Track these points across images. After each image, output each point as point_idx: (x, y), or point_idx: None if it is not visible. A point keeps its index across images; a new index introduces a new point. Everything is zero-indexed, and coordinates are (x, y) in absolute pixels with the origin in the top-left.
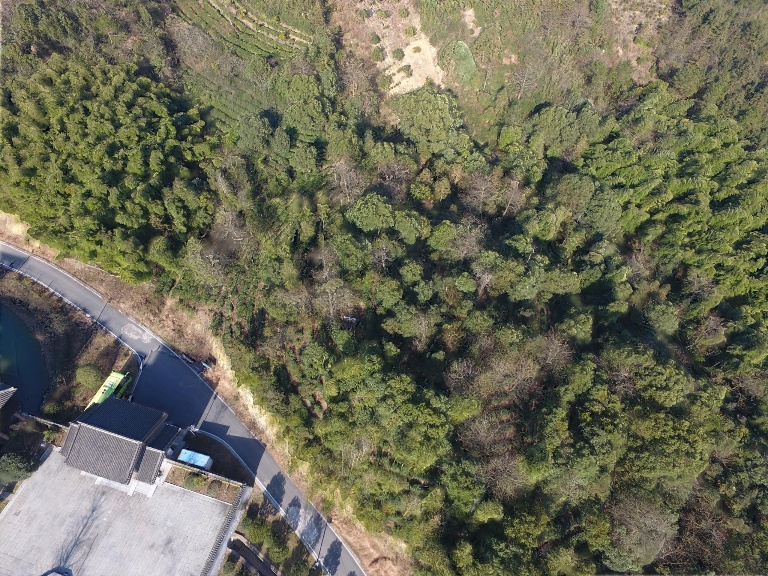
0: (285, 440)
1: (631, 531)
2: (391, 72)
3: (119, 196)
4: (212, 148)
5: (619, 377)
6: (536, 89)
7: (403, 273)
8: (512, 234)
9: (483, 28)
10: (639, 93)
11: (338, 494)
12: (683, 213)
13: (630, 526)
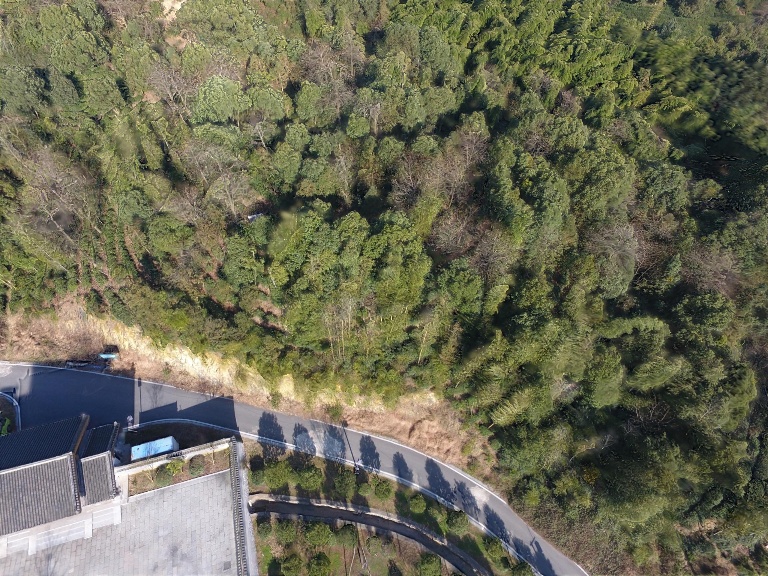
0: (252, 376)
1: (609, 257)
2: None
3: None
4: None
5: (533, 142)
6: None
7: (290, 138)
8: None
9: None
10: None
11: (340, 393)
12: (494, 38)
13: (607, 251)
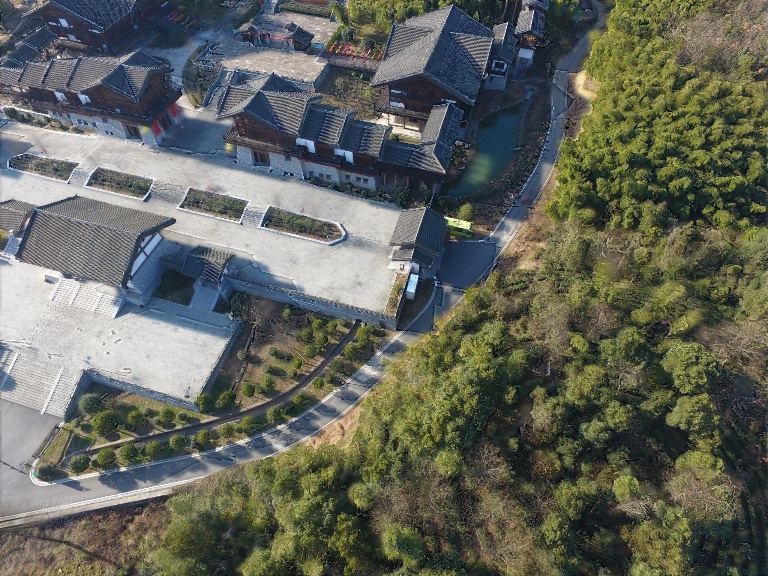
0: None
1: None
2: None
3: (626, 175)
4: (731, 226)
5: None
6: None
7: None
8: None
9: None
10: None
11: None
12: None
13: None
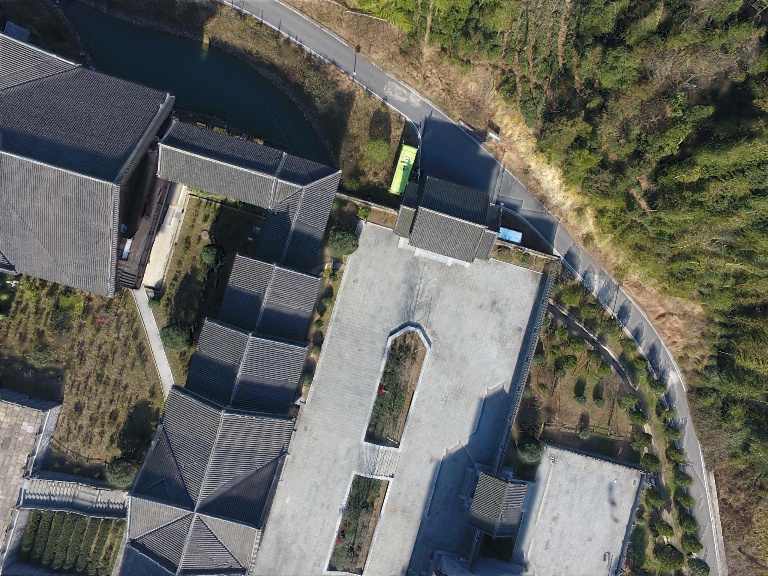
0: (587, 216)
1: None
2: None
3: None
4: None
5: None
6: None
7: None
8: None
9: None
10: None
11: (636, 264)
12: None
13: None
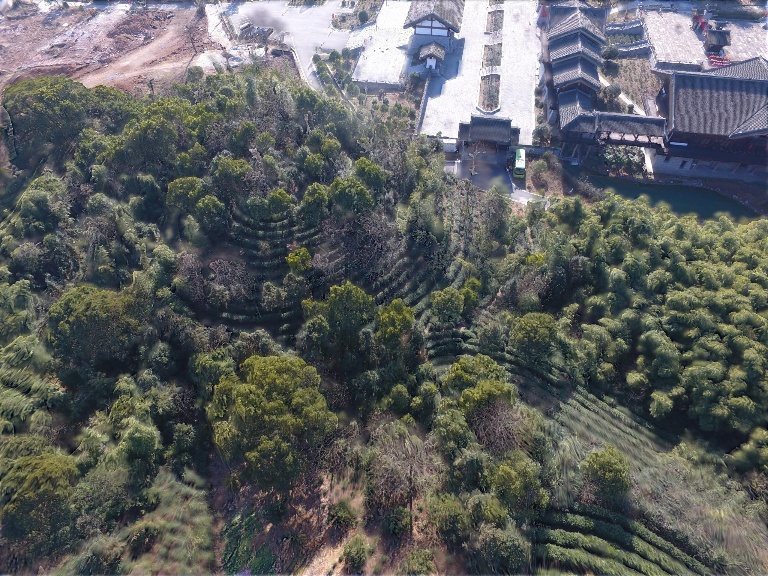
0: None
1: None
2: None
3: None
4: None
5: None
6: None
7: None
8: (206, 256)
9: None
10: None
11: None
12: None
13: None
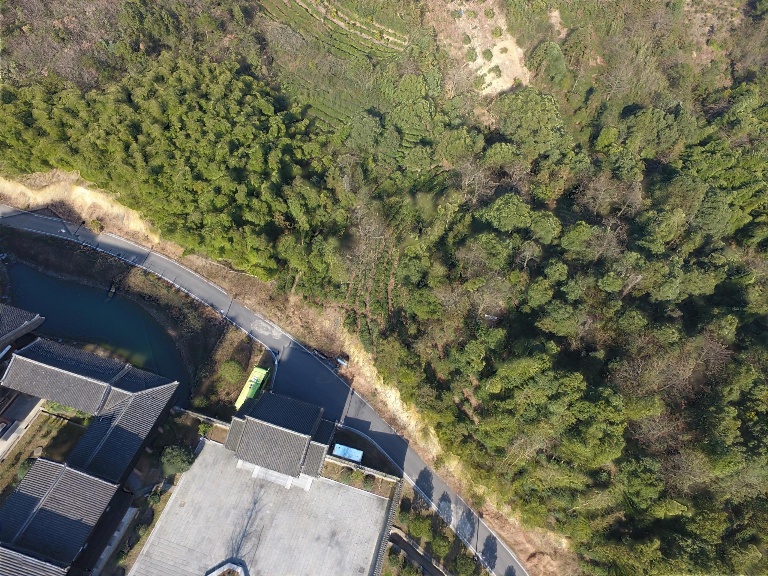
0: (431, 436)
1: None
2: (482, 72)
3: None
4: (320, 147)
5: None
6: (625, 91)
7: (550, 273)
8: None
9: (570, 29)
10: (727, 96)
11: (489, 490)
12: None
13: None
